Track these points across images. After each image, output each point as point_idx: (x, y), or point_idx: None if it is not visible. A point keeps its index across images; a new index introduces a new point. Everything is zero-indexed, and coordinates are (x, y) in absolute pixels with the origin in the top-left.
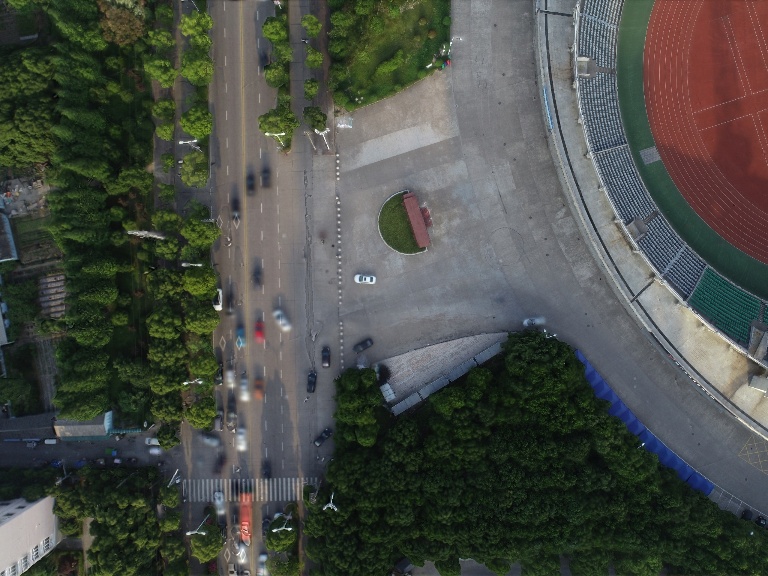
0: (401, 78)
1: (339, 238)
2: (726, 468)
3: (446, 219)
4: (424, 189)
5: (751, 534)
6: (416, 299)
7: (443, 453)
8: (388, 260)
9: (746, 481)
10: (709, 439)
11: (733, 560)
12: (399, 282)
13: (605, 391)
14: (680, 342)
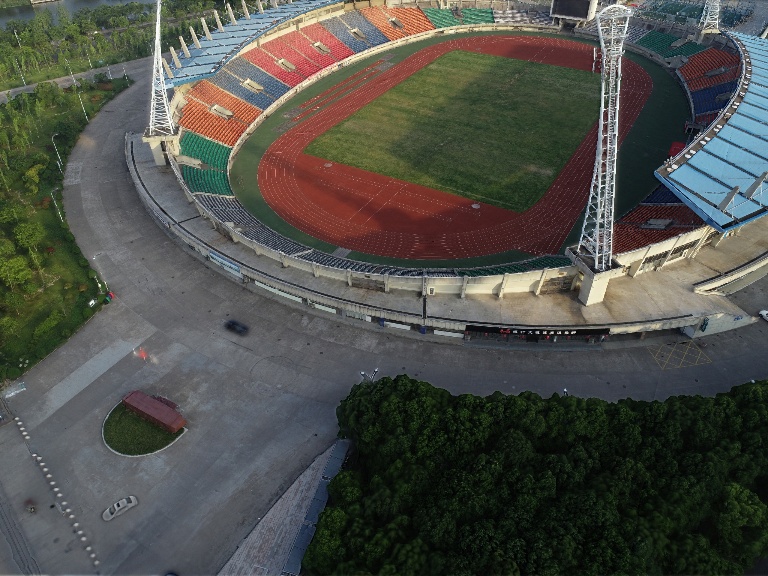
0: (67, 327)
1: (57, 492)
2: (670, 386)
3: (190, 392)
4: (147, 385)
5: (753, 382)
6: (207, 483)
7: None
8: (142, 470)
9: (698, 382)
10: (625, 376)
11: None
12: (171, 482)
13: None
14: (497, 318)
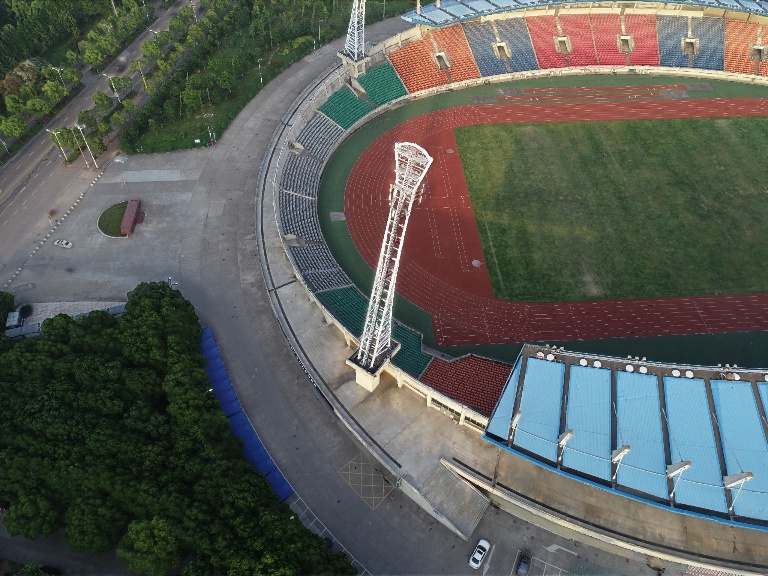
0: (176, 146)
1: (65, 217)
2: (319, 482)
3: (156, 222)
4: (151, 202)
5: (290, 518)
6: (95, 266)
7: (11, 354)
8: (92, 237)
9: (338, 504)
10: (311, 446)
11: (251, 537)
12: (90, 253)
13: (217, 365)
14: (301, 331)
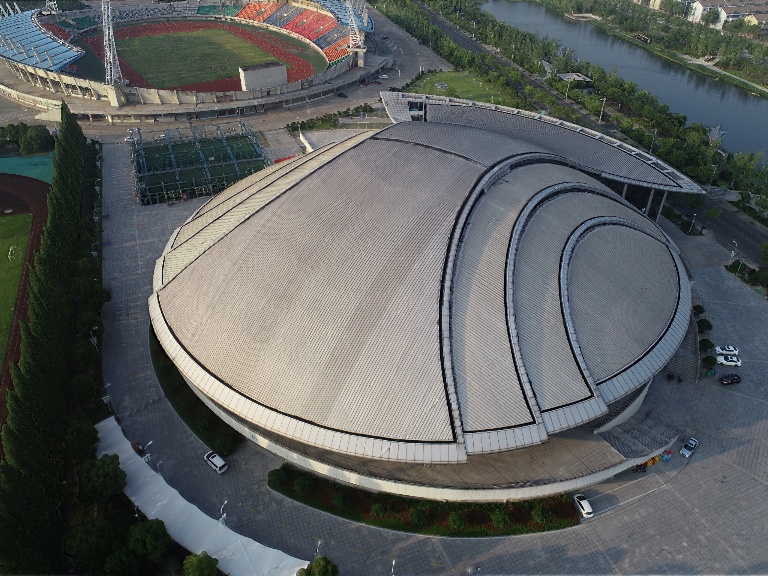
0: None
1: None
2: None
3: None
4: None
5: None
6: None
7: None
8: None
9: None
10: None
11: None
12: None
13: None
14: None
